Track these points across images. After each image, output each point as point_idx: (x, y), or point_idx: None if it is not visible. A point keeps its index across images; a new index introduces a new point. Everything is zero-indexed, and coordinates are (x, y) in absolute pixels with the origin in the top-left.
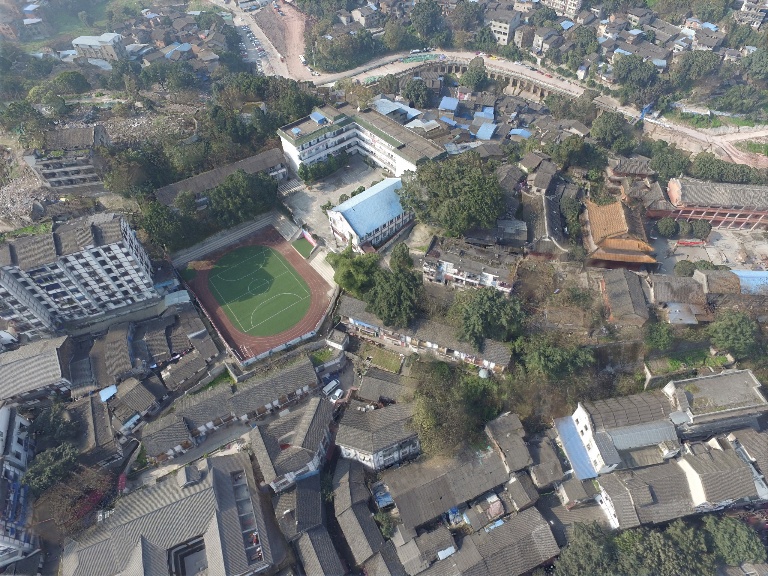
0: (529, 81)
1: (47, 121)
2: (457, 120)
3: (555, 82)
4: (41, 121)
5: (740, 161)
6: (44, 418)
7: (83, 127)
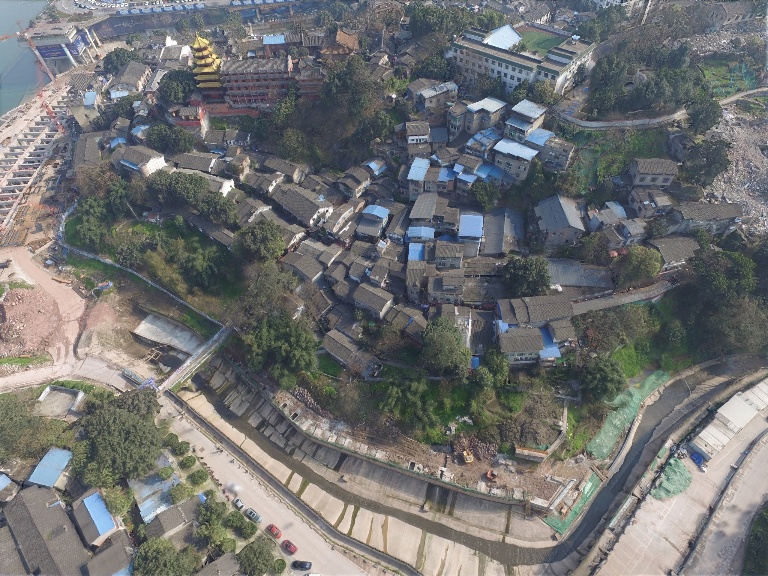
0: (321, 515)
1: (766, 3)
2: (455, 212)
3: (266, 506)
4: (767, 0)
5: (71, 333)
6: (591, 1)
7: (762, 33)
